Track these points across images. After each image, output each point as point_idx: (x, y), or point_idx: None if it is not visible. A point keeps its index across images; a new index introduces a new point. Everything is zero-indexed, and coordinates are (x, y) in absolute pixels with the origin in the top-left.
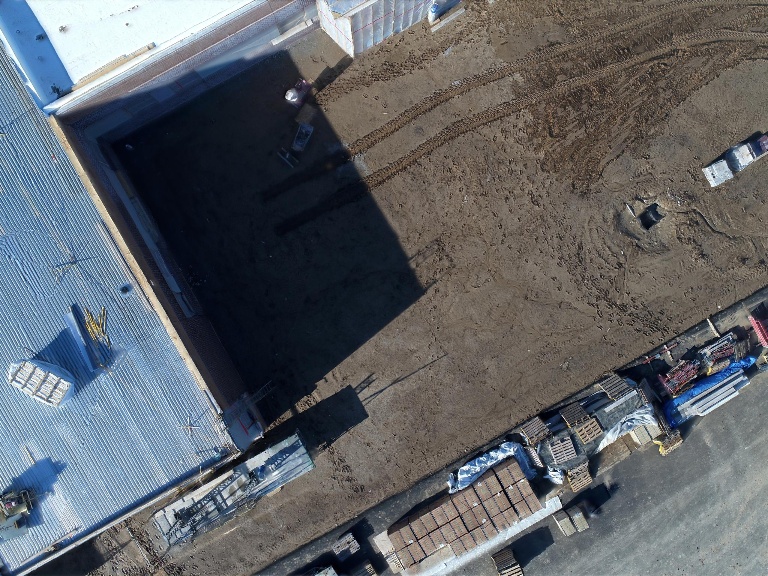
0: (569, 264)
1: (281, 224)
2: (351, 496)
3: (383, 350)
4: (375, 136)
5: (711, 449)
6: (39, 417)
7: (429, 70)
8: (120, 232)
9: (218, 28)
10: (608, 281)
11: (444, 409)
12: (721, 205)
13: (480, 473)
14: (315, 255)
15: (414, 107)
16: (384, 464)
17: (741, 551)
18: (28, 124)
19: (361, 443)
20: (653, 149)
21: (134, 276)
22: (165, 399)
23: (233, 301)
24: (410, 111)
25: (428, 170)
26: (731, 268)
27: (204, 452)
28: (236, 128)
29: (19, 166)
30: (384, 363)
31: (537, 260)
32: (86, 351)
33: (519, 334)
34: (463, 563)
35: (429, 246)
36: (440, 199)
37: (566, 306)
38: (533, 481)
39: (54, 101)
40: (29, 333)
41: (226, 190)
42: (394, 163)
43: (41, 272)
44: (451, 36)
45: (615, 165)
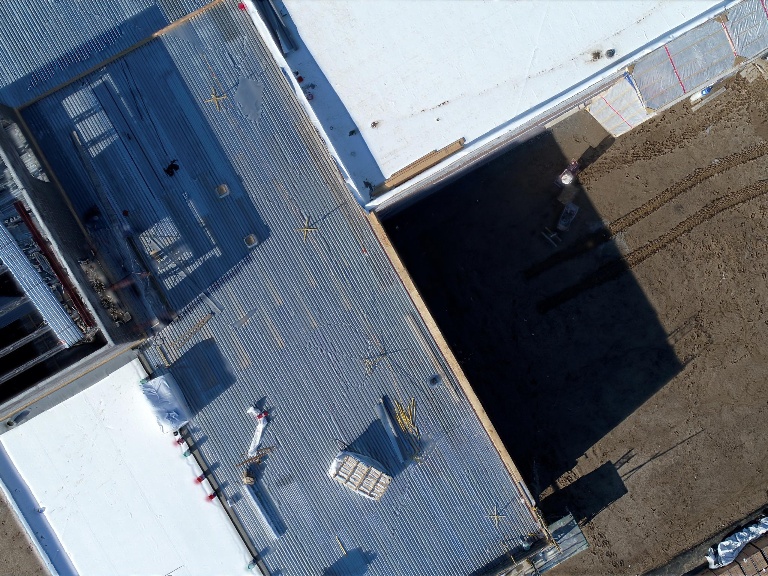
0: None
1: (543, 302)
2: (611, 571)
3: (642, 426)
4: (636, 214)
5: None
6: (350, 508)
7: (689, 149)
8: (438, 327)
9: (533, 124)
10: None
11: (702, 484)
12: None
13: (740, 548)
14: (576, 332)
15: (675, 186)
16: (643, 539)
17: None
18: (340, 219)
19: (620, 518)
20: None
21: (442, 367)
22: (472, 489)
23: (496, 379)
24: (671, 189)
25: (688, 247)
26: None
27: (510, 541)
28: (500, 208)
29: (331, 260)
30: (643, 439)
31: None
32: (397, 442)
33: None
34: None
35: (687, 322)
36: (699, 276)
37: None
38: None
39: (376, 199)
40: (341, 425)
41: (490, 269)
42: (654, 241)
43: (344, 362)
44: (711, 115)
45: None
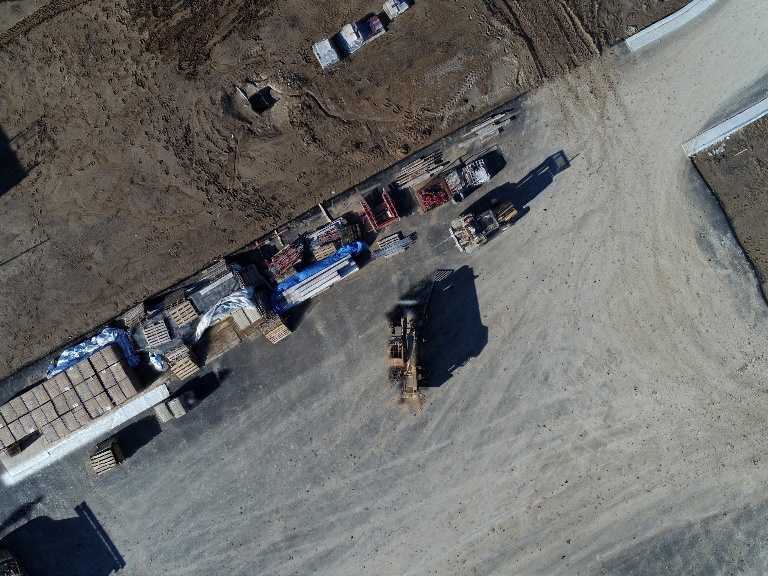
0: (176, 147)
1: None
2: None
3: None
4: None
5: (324, 337)
6: None
7: None
8: None
9: None
10: (218, 165)
11: (48, 295)
12: (334, 88)
13: (81, 359)
14: None
15: None
16: None
17: (355, 442)
18: None
19: None
20: (262, 30)
21: None
22: None
23: None
24: None
25: (27, 49)
26: (344, 152)
27: None
28: None
29: None
30: None
31: (143, 143)
32: None
33: (126, 219)
34: (67, 452)
35: (30, 127)
36: (40, 79)
37: (174, 190)
38: (136, 368)
39: None
40: None
41: None
42: None
43: None
44: None
45: (222, 46)
